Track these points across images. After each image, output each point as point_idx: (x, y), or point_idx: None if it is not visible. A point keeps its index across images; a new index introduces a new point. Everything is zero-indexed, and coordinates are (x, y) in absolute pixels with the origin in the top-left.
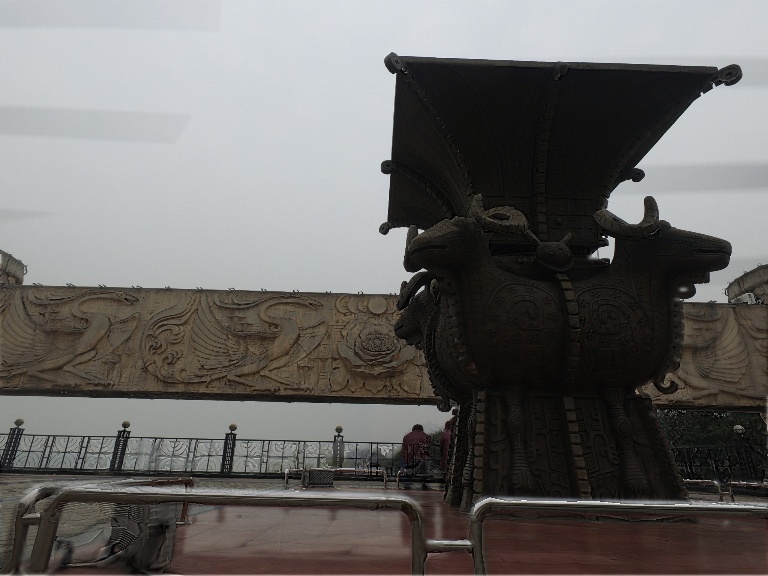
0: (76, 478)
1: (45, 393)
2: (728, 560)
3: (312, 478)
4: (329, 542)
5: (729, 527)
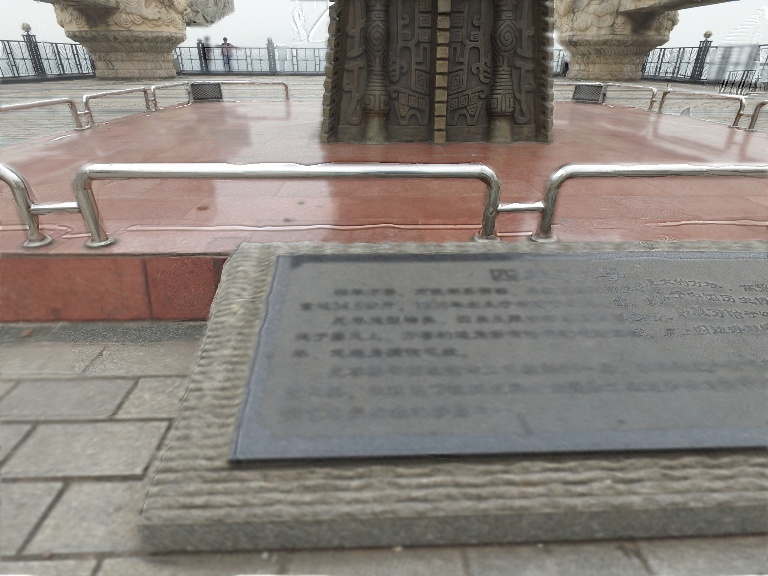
0: (692, 90)
1: (693, 3)
2: (162, 127)
3: (578, 93)
4: (236, 107)
5: (285, 144)
